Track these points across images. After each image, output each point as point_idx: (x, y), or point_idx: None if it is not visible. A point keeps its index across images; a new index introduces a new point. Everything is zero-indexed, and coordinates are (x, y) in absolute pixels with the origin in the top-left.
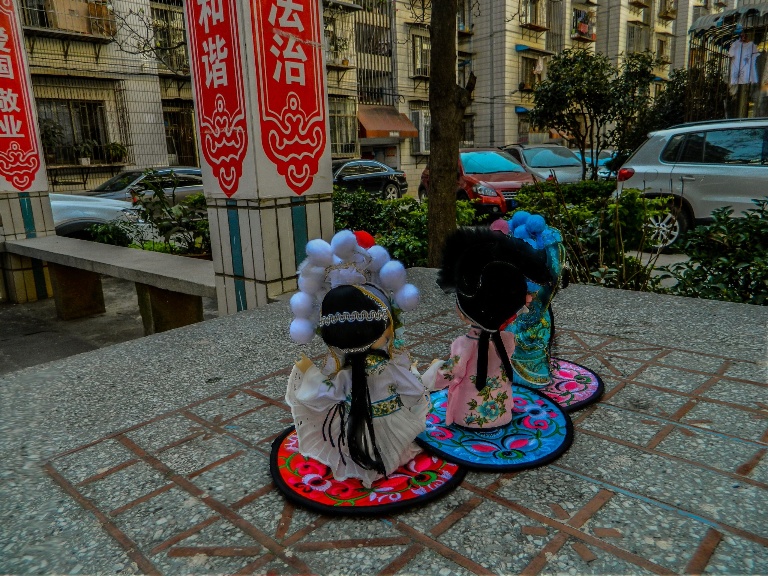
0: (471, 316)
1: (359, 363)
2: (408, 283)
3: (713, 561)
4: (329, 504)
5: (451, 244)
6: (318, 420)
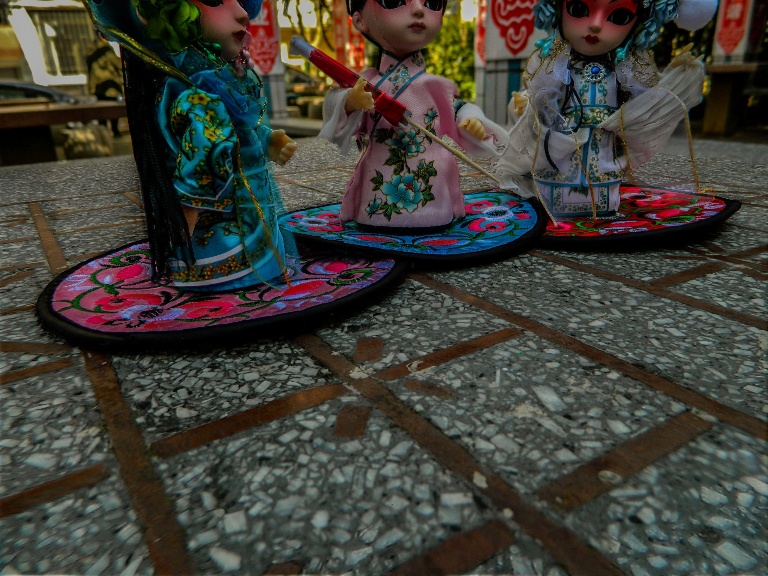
0: None
1: None
2: None
3: None
4: None
5: None
6: None
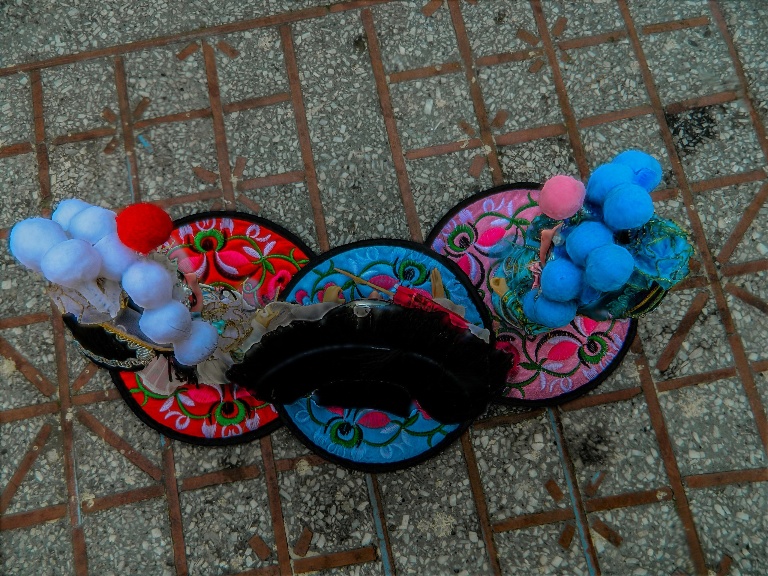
0: None
1: None
2: None
3: None
4: (127, 386)
5: (271, 345)
6: None
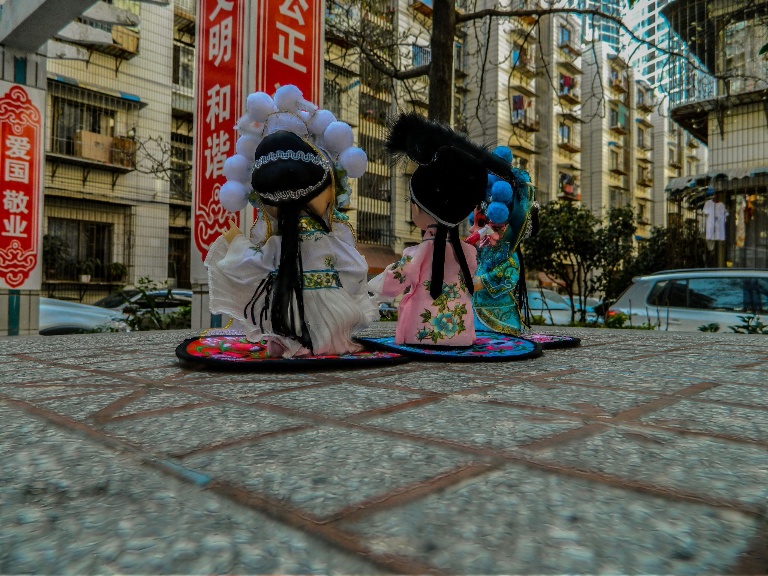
0: (426, 205)
1: (291, 216)
2: (382, 324)
3: (710, 391)
4: (235, 361)
5: (405, 119)
6: (241, 298)
